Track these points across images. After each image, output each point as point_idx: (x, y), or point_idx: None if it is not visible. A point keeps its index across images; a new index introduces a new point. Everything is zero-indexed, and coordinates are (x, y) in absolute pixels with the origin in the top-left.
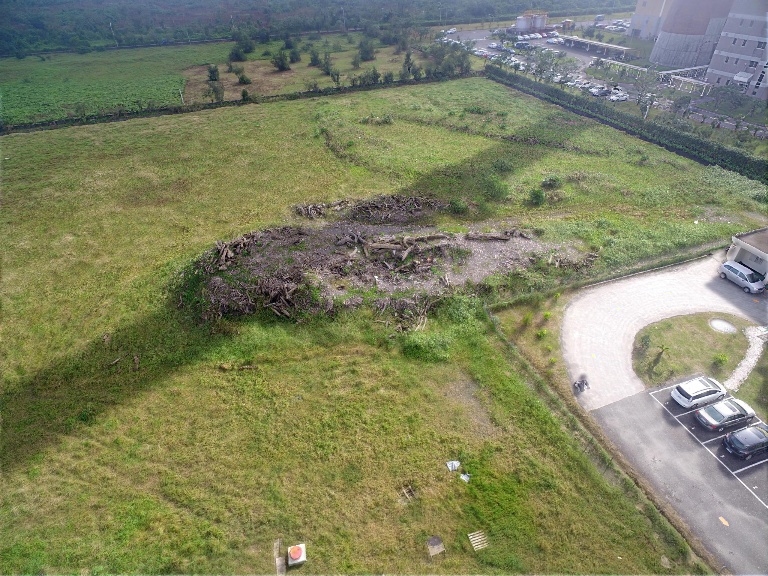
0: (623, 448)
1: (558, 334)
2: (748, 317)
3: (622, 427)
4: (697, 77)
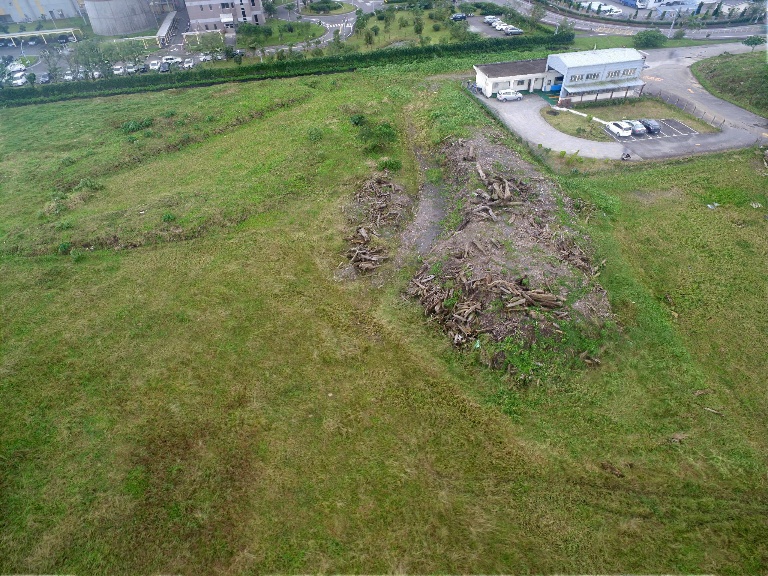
0: (667, 156)
1: (576, 156)
2: (543, 106)
3: (652, 154)
4: (174, 33)
